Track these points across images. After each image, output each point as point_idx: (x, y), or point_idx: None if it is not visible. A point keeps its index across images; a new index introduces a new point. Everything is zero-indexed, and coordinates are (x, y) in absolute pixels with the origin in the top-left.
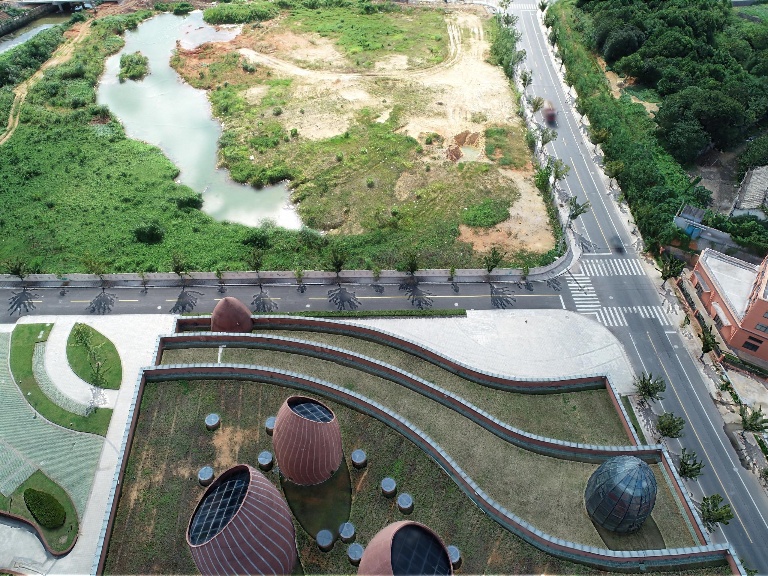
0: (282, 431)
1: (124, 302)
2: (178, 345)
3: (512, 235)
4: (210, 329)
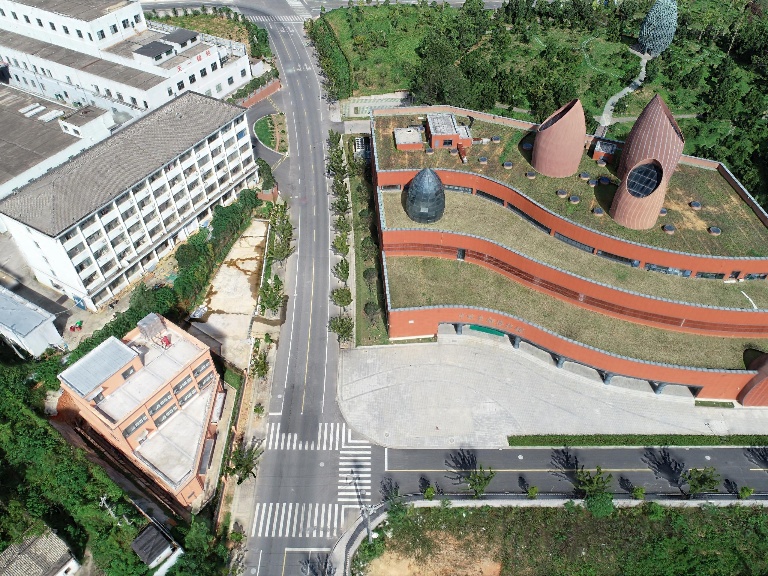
0: None
1: None
2: None
3: None
4: None
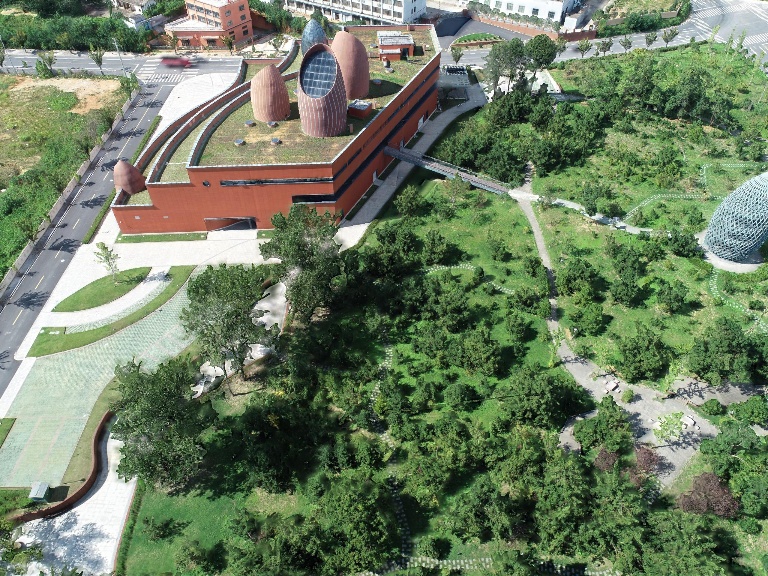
0: (274, 80)
1: (40, 285)
2: None
3: (95, 94)
4: (130, 195)
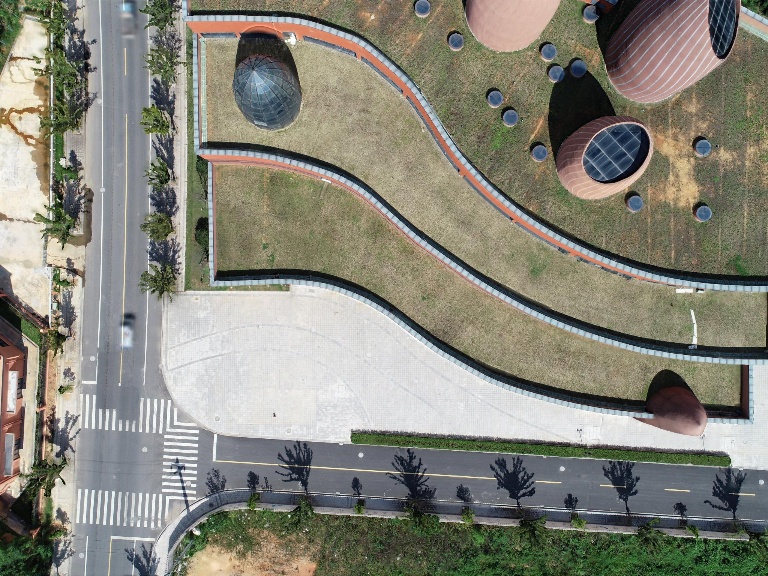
0: None
1: None
2: (750, 354)
3: None
4: None
